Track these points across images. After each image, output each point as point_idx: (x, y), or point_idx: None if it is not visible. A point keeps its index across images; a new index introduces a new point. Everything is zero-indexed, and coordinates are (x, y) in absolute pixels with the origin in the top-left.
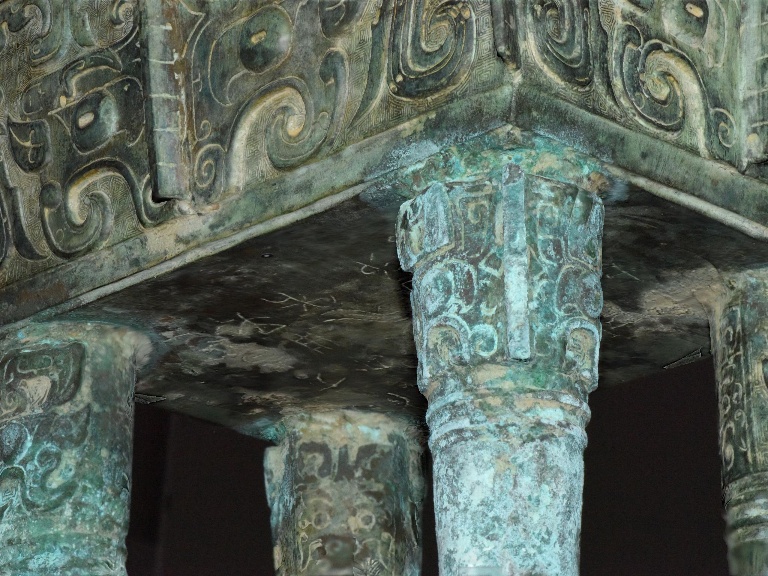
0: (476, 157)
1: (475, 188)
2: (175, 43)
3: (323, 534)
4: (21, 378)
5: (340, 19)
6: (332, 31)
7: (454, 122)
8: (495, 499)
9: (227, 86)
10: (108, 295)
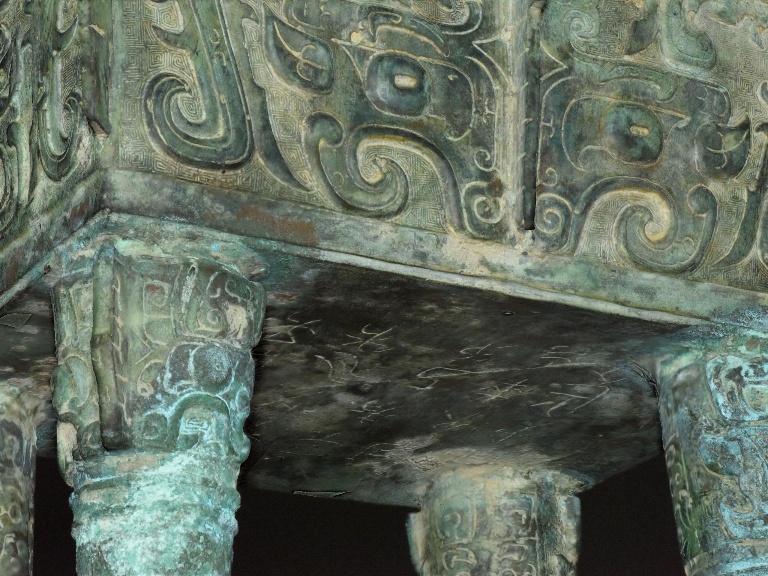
0: None
1: None
2: None
3: None
4: (228, 299)
5: (722, 166)
6: (713, 172)
7: None
8: None
9: (582, 150)
10: (359, 266)
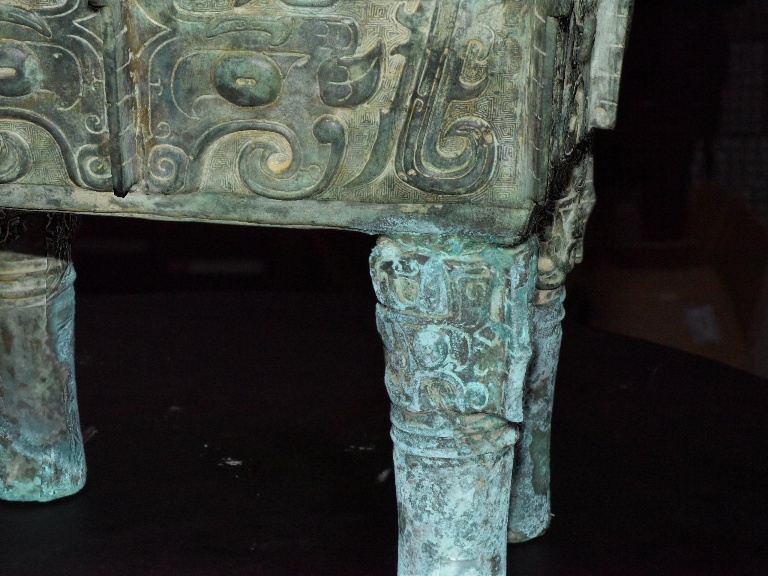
0: (475, 243)
1: (474, 271)
2: (130, 43)
3: (21, 213)
4: None
5: (346, 98)
6: (335, 105)
7: (462, 219)
8: (474, 510)
9: (194, 101)
10: (8, 209)
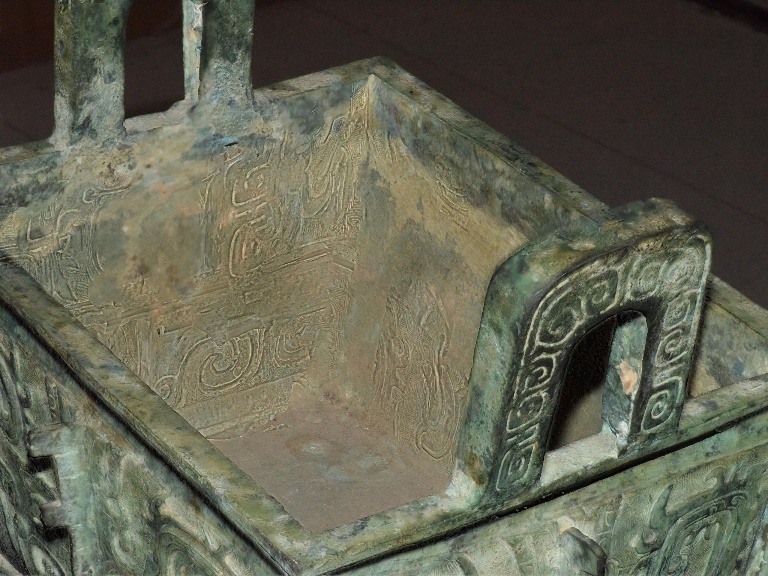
0: None
1: None
2: None
3: None
4: None
5: None
6: None
7: None
8: None
9: None
10: None
